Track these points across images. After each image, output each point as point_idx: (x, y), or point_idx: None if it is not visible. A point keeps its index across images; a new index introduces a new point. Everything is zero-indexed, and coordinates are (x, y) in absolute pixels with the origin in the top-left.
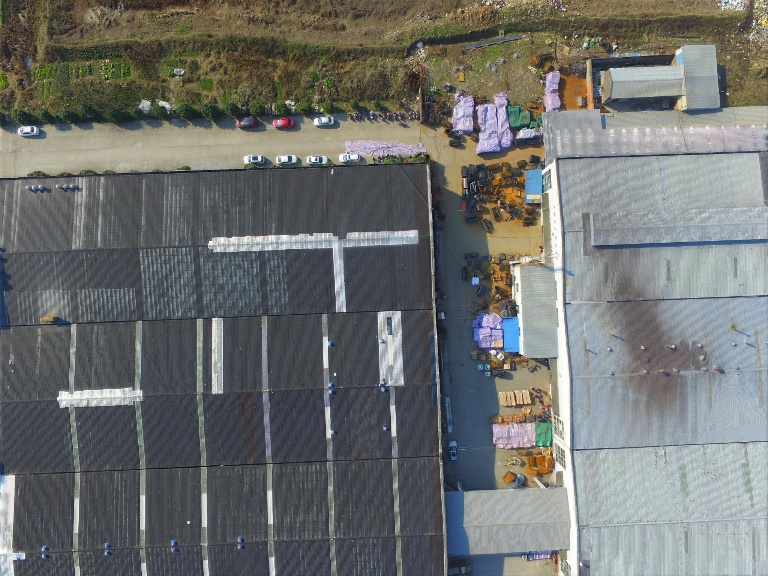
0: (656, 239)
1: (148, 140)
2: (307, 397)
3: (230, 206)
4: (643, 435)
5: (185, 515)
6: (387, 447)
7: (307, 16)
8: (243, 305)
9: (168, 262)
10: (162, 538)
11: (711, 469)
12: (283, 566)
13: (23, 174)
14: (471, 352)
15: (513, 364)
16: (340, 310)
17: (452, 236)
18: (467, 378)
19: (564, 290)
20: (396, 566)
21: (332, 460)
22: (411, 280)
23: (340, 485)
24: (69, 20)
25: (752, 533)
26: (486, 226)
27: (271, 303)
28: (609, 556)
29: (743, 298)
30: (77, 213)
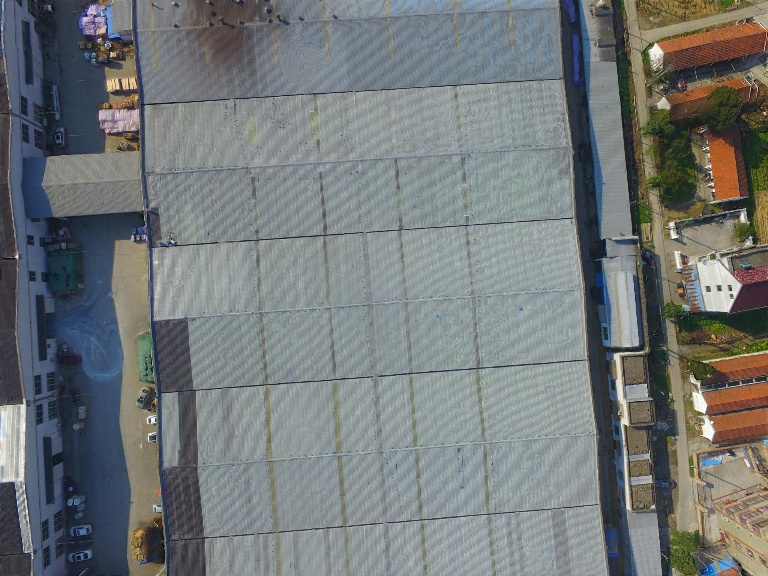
0: None
1: None
2: None
3: None
4: (212, 88)
5: None
6: None
7: None
8: None
9: None
10: None
11: (280, 119)
12: None
13: None
14: (79, 42)
15: (121, 53)
16: None
17: None
18: (77, 69)
19: None
20: None
21: None
22: None
23: None
24: None
25: (319, 178)
26: None
27: None
28: (178, 204)
29: None
30: None
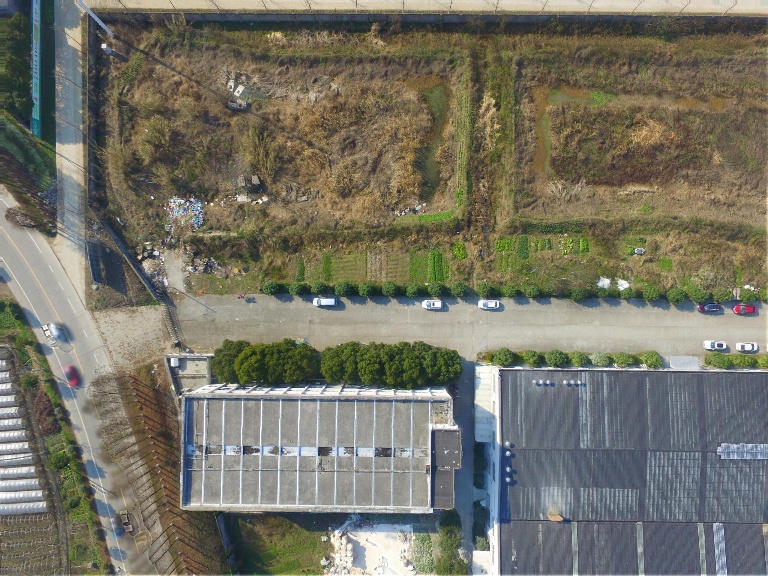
0: None
1: (606, 318)
2: None
3: (735, 410)
4: None
5: None
6: None
7: (767, 200)
8: (745, 512)
9: (675, 466)
10: None
11: None
12: None
13: (480, 346)
14: None
15: None
16: None
17: None
18: None
19: None
20: None
21: None
22: None
23: None
24: (531, 193)
25: None
26: None
27: None
28: None
29: None
30: (583, 410)
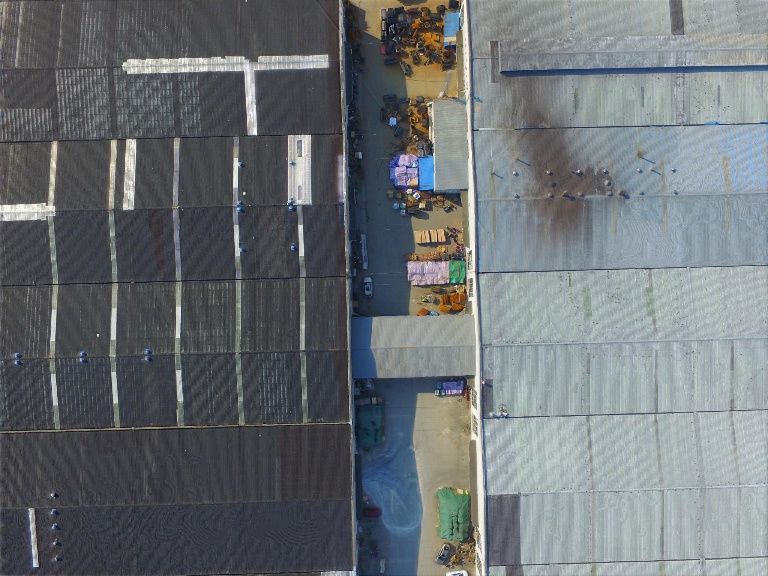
0: (562, 65)
1: None
2: (216, 215)
3: (145, 30)
4: (548, 259)
5: (95, 328)
6: (295, 267)
7: None
8: (156, 127)
9: (83, 83)
10: (72, 349)
11: (615, 293)
12: (190, 379)
13: None
14: (387, 191)
15: (429, 203)
16: (251, 133)
17: (371, 79)
18: (384, 217)
19: (472, 116)
20: (301, 381)
21: (241, 278)
22: (321, 104)
23: (248, 302)
24: None
25: (654, 356)
26: (404, 68)
27: (184, 125)
28: (512, 376)
29: (650, 127)
30: None
